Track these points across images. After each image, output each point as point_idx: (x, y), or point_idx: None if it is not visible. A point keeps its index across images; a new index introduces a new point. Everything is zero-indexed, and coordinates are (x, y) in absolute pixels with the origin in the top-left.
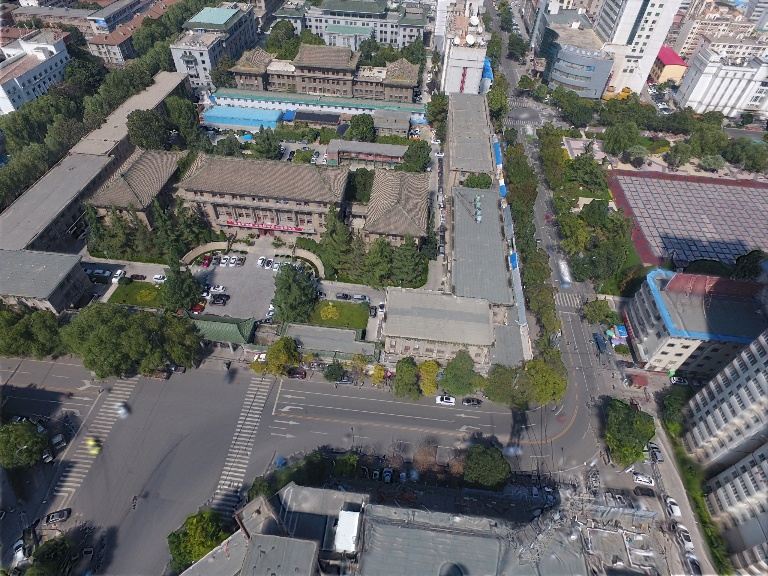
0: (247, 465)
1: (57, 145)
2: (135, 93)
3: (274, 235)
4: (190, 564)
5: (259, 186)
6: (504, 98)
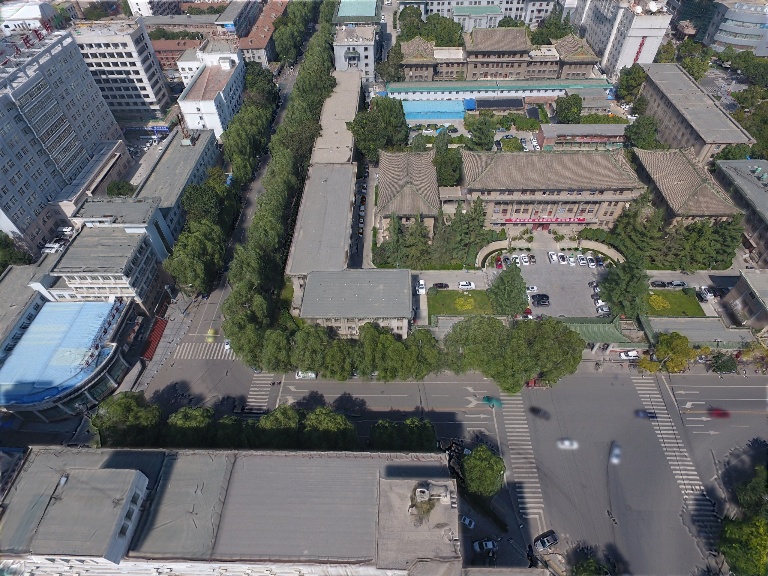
0: (694, 467)
1: (292, 157)
2: (327, 96)
3: (548, 228)
4: (759, 575)
5: (553, 179)
6: (706, 64)
